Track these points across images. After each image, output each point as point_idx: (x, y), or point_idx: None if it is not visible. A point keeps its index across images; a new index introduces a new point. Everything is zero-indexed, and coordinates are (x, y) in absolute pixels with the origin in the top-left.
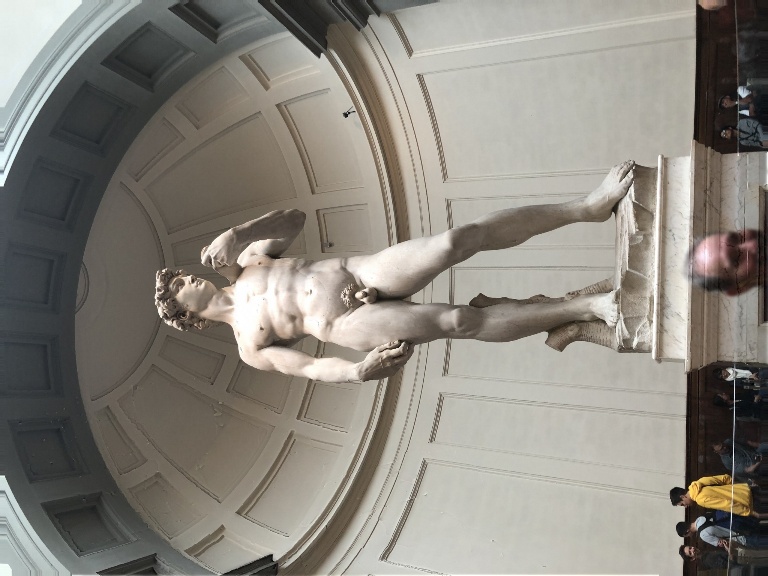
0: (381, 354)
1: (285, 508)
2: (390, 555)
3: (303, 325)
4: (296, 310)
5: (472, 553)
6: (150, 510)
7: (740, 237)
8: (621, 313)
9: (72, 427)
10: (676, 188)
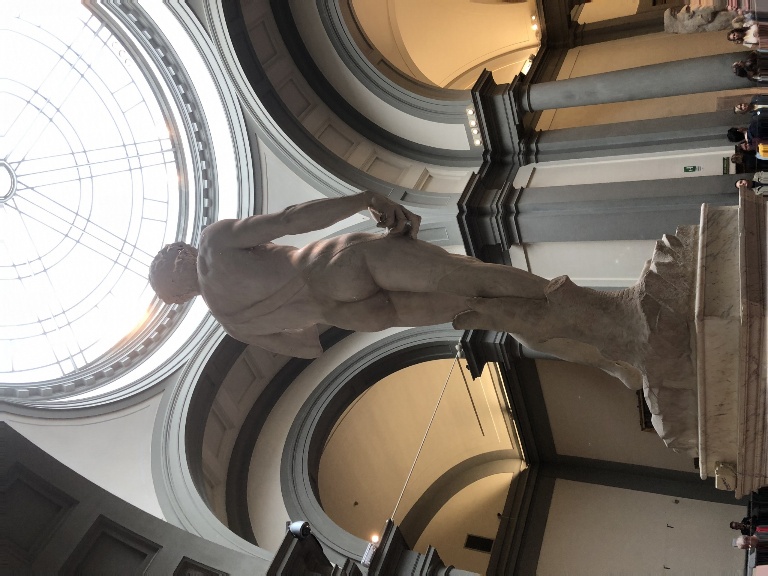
0: None
1: None
2: None
3: None
4: None
5: None
6: None
7: None
8: None
9: None
10: None
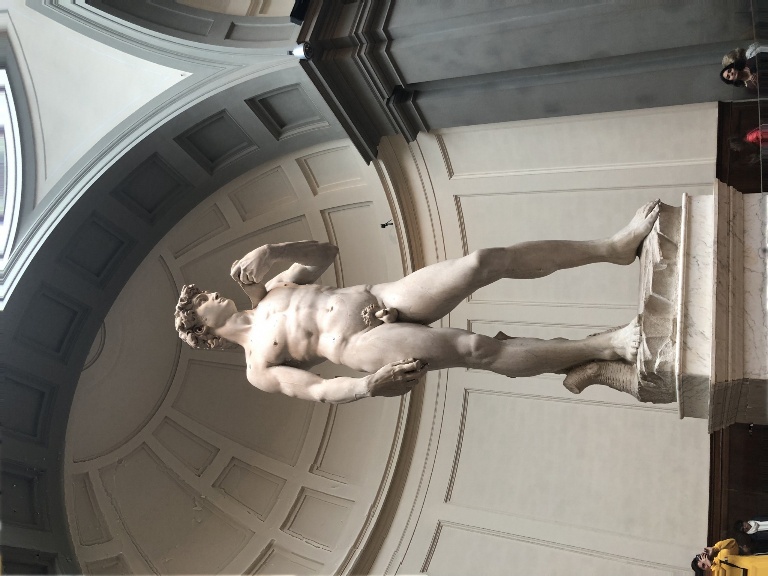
0: (394, 367)
1: None
2: None
3: (318, 343)
4: (314, 326)
5: None
6: None
7: (764, 264)
8: (643, 333)
9: (47, 480)
10: (700, 221)
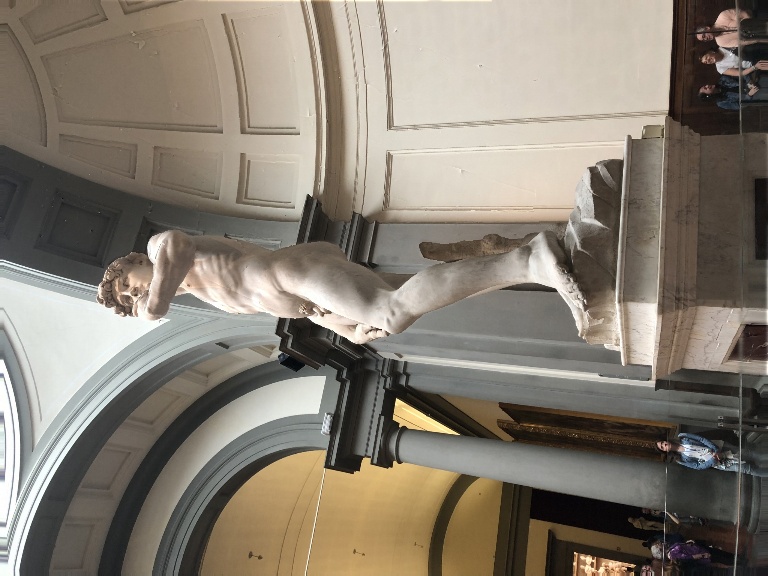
0: (369, 338)
1: (276, 103)
2: (394, 120)
3: None
4: None
5: (464, 82)
6: (181, 184)
7: None
8: None
9: (68, 193)
10: None
